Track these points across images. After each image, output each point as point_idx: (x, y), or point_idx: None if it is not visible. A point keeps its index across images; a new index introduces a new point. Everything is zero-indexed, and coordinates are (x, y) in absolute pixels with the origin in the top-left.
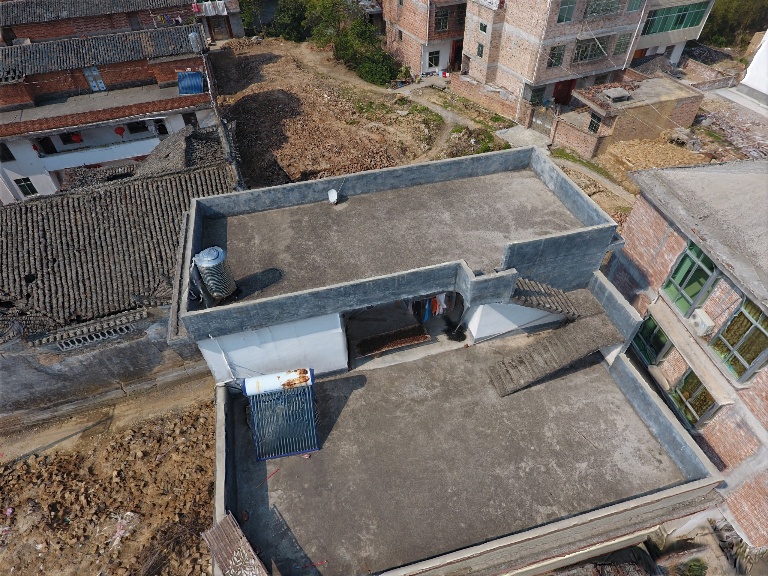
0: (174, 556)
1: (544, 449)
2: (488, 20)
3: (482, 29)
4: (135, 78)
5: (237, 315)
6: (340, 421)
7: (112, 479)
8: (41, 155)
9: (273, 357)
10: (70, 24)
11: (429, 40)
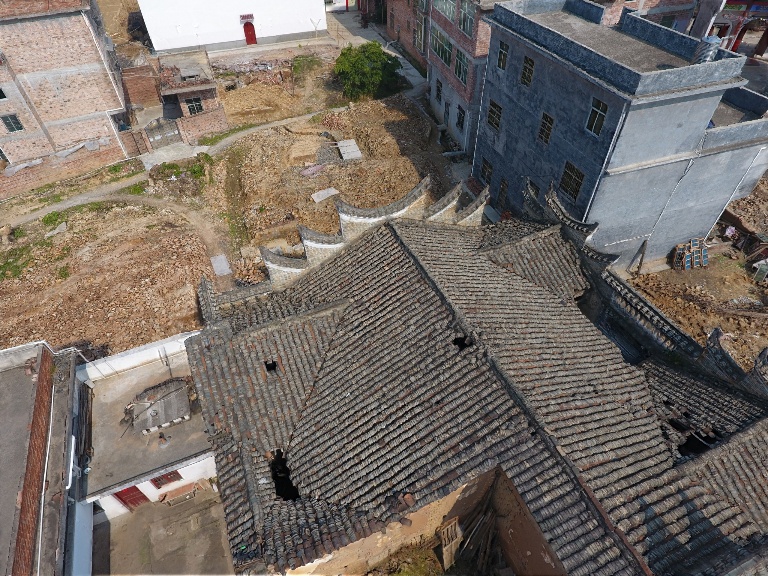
0: None
1: None
2: None
3: None
4: None
5: None
6: None
7: None
8: None
9: None
10: None
11: None
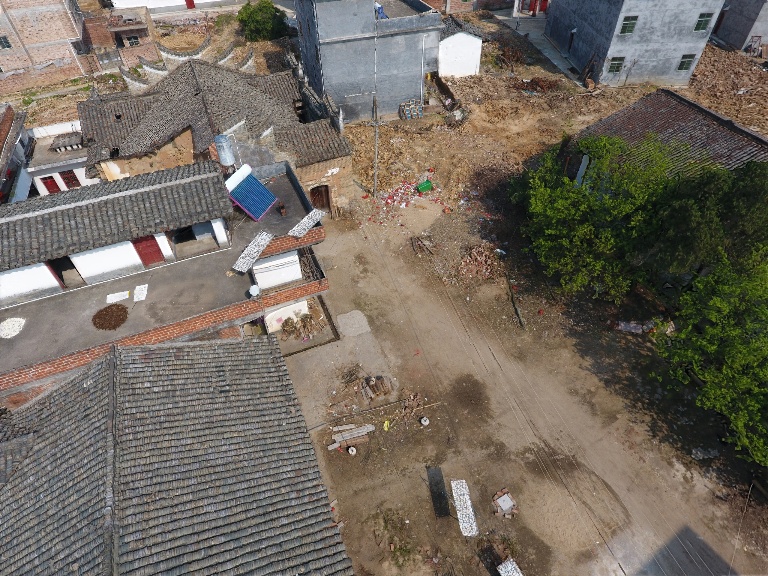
0: None
1: (387, 4)
2: None
3: None
4: None
5: None
6: None
7: None
8: None
9: None
10: None
11: None
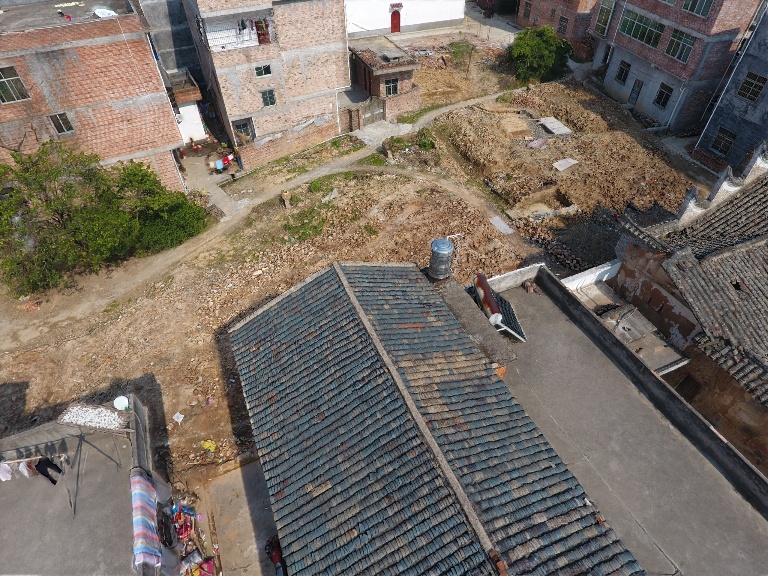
0: None
1: None
2: (271, 57)
3: (262, 73)
4: None
5: None
6: None
7: None
8: None
9: None
10: None
11: None
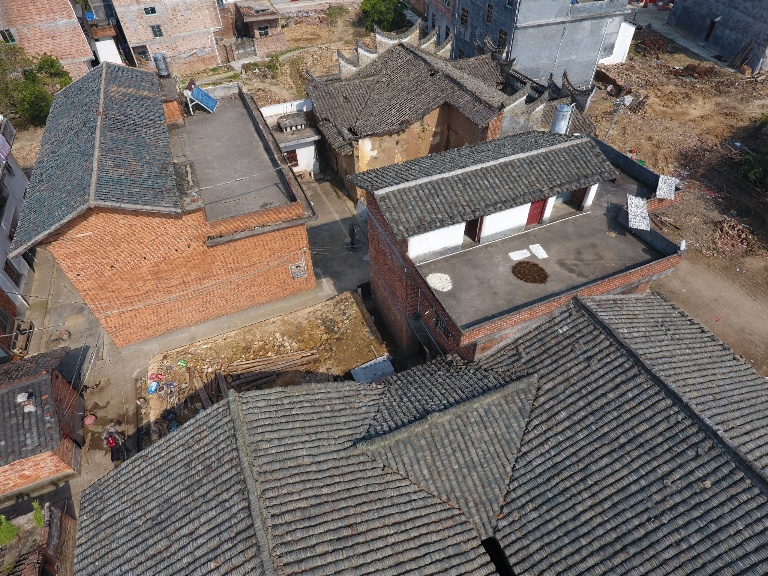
0: None
1: None
2: (155, 1)
3: (150, 12)
4: None
5: None
6: None
7: None
8: None
9: None
10: None
11: None
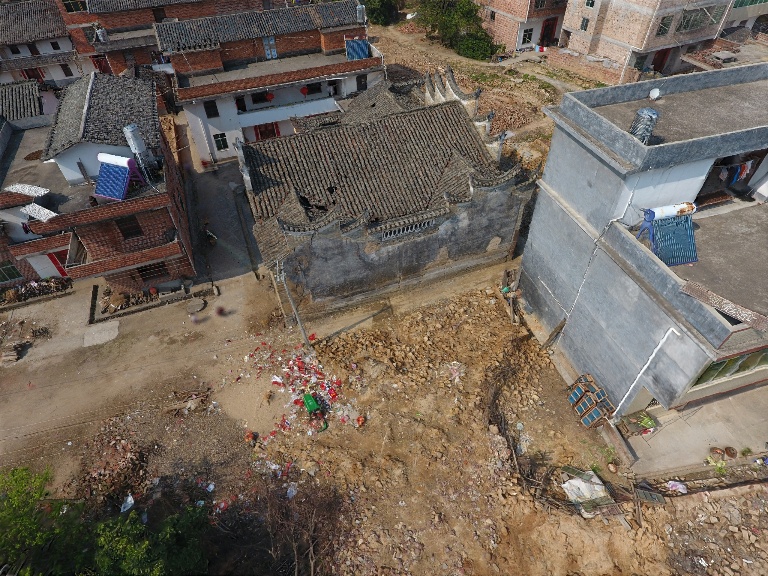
0: (506, 388)
1: None
2: None
3: (589, 4)
4: (303, 47)
5: (675, 151)
6: (699, 247)
7: (425, 343)
8: (239, 112)
9: (654, 199)
10: (213, 5)
11: (528, 18)
